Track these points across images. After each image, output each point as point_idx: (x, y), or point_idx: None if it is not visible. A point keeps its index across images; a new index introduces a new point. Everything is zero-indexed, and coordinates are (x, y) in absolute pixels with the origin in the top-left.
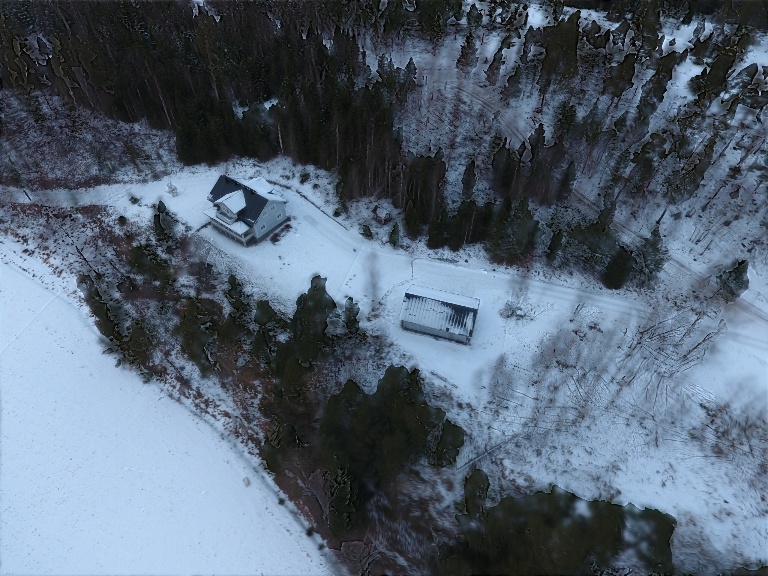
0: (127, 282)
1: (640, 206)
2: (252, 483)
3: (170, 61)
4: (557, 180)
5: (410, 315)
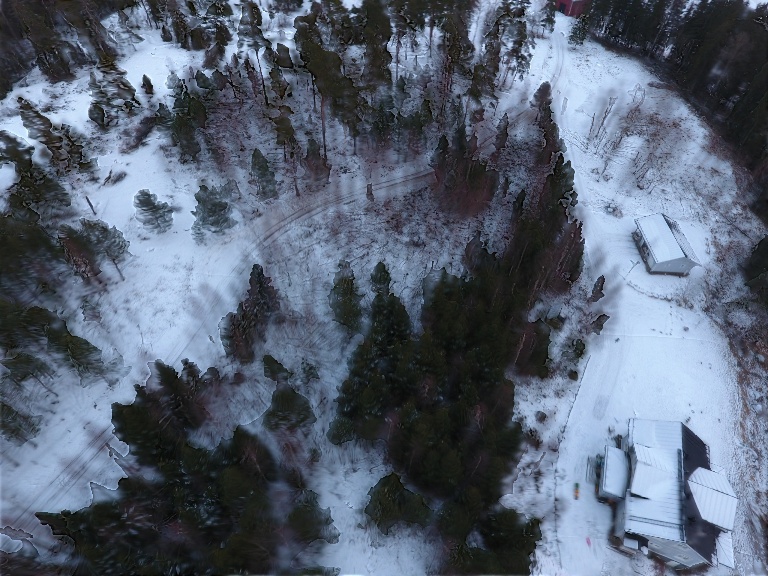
0: None
1: None
2: None
3: None
4: None
5: (695, 257)
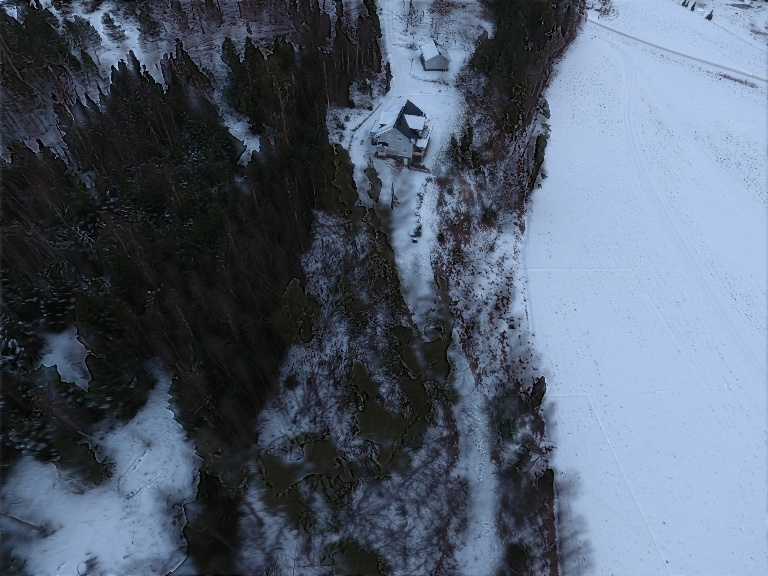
0: (489, 212)
1: None
2: None
3: (234, 181)
4: None
5: (448, 57)
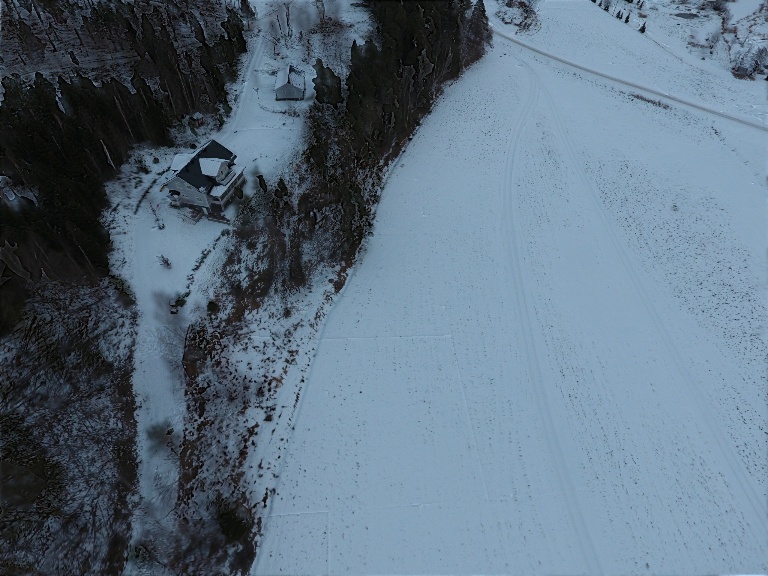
0: (295, 269)
1: (178, 34)
2: None
3: None
4: None
5: (300, 85)
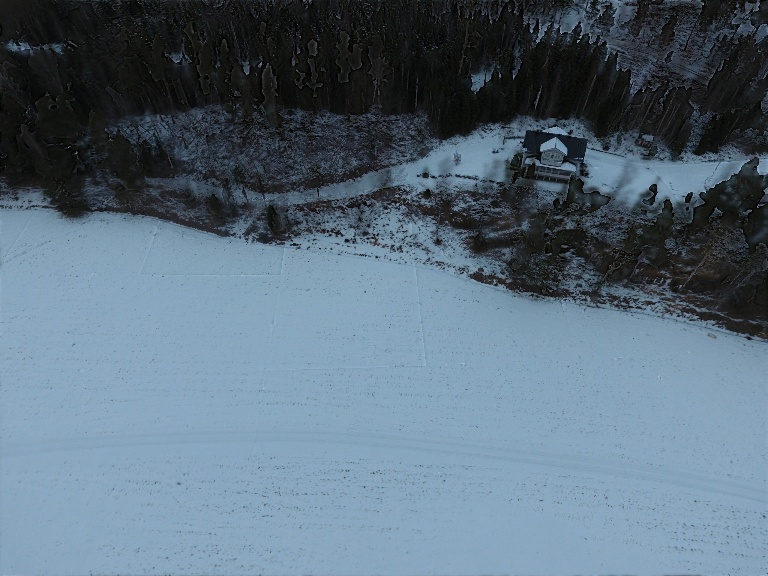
0: (480, 237)
1: None
2: (717, 335)
3: (396, 50)
4: (755, 90)
5: None
